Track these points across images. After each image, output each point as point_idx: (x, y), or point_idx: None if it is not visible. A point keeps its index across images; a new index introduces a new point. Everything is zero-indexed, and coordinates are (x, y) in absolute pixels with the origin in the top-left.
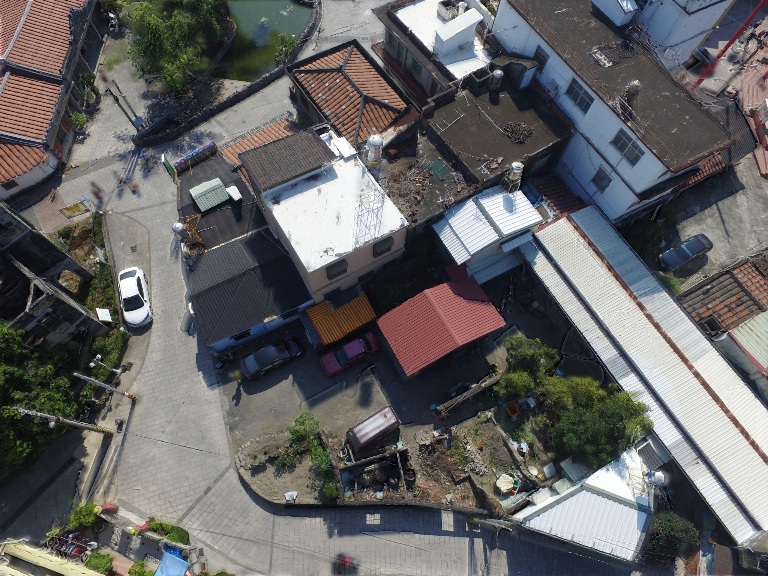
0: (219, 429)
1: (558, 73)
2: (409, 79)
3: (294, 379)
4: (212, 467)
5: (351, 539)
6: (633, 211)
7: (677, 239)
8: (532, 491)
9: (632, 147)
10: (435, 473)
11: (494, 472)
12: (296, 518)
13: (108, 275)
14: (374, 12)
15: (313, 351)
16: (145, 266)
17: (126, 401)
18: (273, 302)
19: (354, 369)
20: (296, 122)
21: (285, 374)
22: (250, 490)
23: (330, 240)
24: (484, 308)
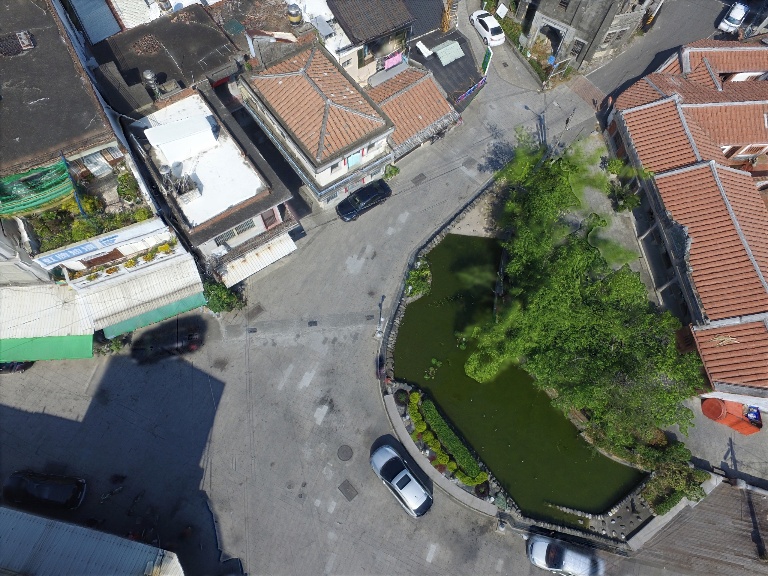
0: None
1: None
2: None
3: None
4: None
5: None
6: None
7: None
8: None
9: None
10: None
11: None
12: None
13: (514, 40)
14: None
15: None
16: None
17: None
18: None
19: None
20: None
21: None
22: None
23: None
24: None
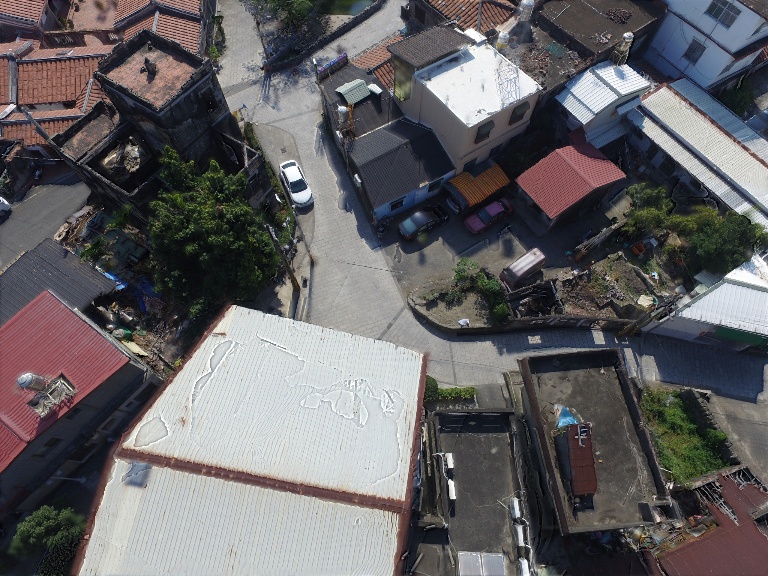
0: (389, 280)
1: None
2: None
3: (444, 240)
4: (389, 309)
5: (519, 355)
6: (722, 80)
7: (757, 110)
8: (671, 303)
9: (728, 10)
10: (580, 302)
11: (631, 298)
12: (469, 342)
13: (269, 169)
14: None
15: (455, 218)
16: (297, 162)
17: (305, 264)
18: (424, 171)
19: (494, 229)
20: None
21: (435, 237)
22: (425, 324)
23: (480, 103)
24: (606, 164)
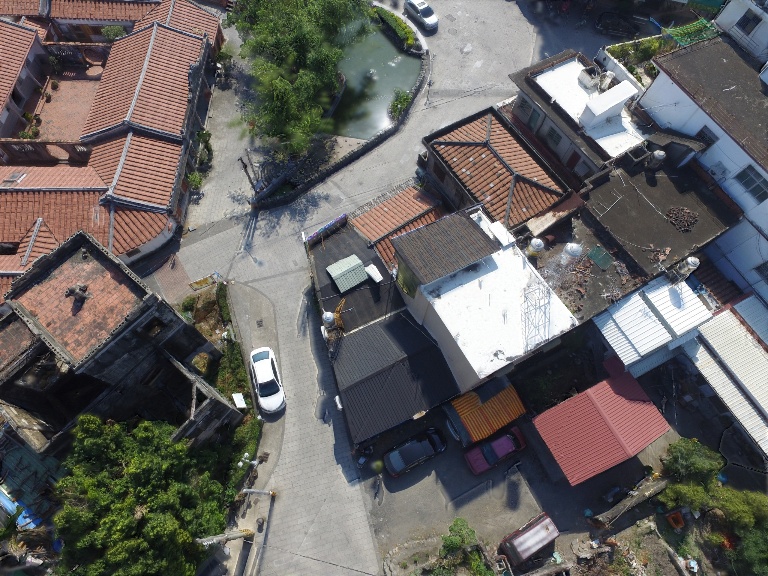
0: (364, 531)
1: (728, 157)
2: (545, 148)
3: (437, 476)
4: (360, 575)
5: None
6: None
7: None
8: None
9: None
10: None
11: None
12: None
13: (238, 354)
14: (511, 78)
15: (455, 444)
16: (273, 343)
17: (265, 496)
18: (421, 396)
19: (500, 466)
20: (424, 190)
21: (427, 470)
22: None
23: (499, 341)
24: (647, 409)
